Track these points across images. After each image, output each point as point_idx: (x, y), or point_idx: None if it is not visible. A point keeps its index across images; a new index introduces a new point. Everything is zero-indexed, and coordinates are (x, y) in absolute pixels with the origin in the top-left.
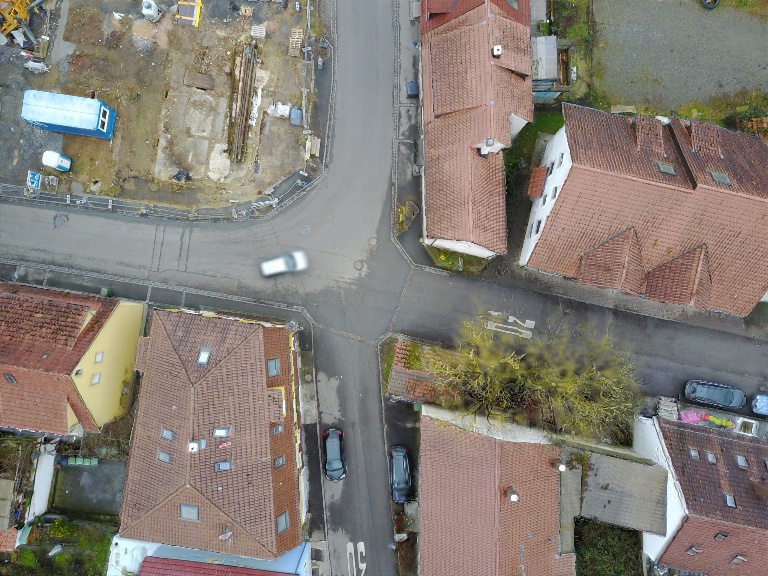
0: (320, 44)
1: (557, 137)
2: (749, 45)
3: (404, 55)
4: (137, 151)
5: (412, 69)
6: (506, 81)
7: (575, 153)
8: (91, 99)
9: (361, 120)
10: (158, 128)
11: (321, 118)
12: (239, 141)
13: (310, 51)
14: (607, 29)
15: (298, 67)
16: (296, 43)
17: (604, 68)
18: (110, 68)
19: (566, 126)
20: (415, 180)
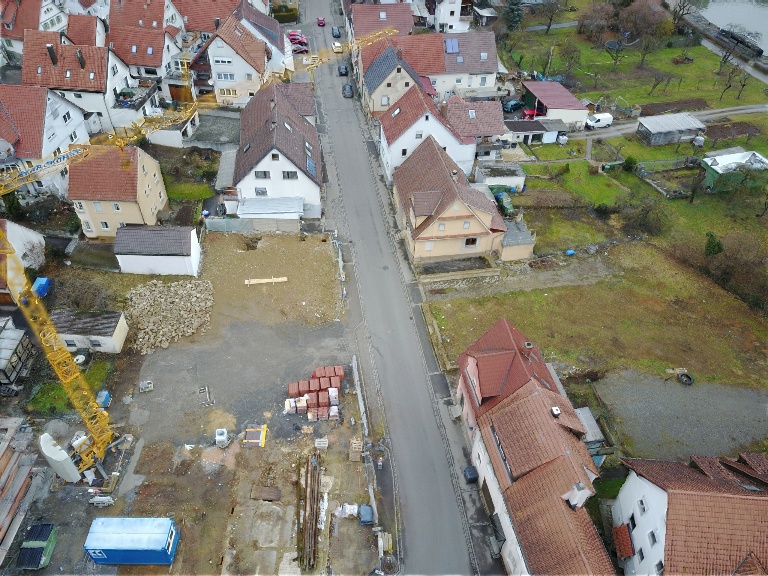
0: (377, 448)
1: (623, 493)
2: (735, 406)
3: (454, 448)
4: (198, 573)
5: (464, 458)
6: (569, 438)
7: (662, 484)
8: (162, 519)
9: (428, 510)
10: (223, 545)
11: (388, 513)
12: (310, 545)
13: (368, 455)
14: (617, 408)
15: (359, 470)
16: (358, 447)
17: (629, 437)
18: (177, 493)
19: (636, 469)
20: (496, 563)
